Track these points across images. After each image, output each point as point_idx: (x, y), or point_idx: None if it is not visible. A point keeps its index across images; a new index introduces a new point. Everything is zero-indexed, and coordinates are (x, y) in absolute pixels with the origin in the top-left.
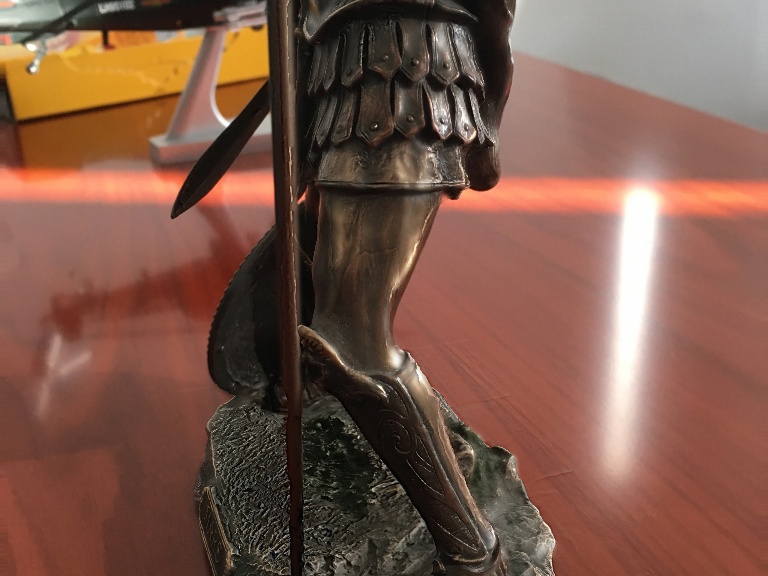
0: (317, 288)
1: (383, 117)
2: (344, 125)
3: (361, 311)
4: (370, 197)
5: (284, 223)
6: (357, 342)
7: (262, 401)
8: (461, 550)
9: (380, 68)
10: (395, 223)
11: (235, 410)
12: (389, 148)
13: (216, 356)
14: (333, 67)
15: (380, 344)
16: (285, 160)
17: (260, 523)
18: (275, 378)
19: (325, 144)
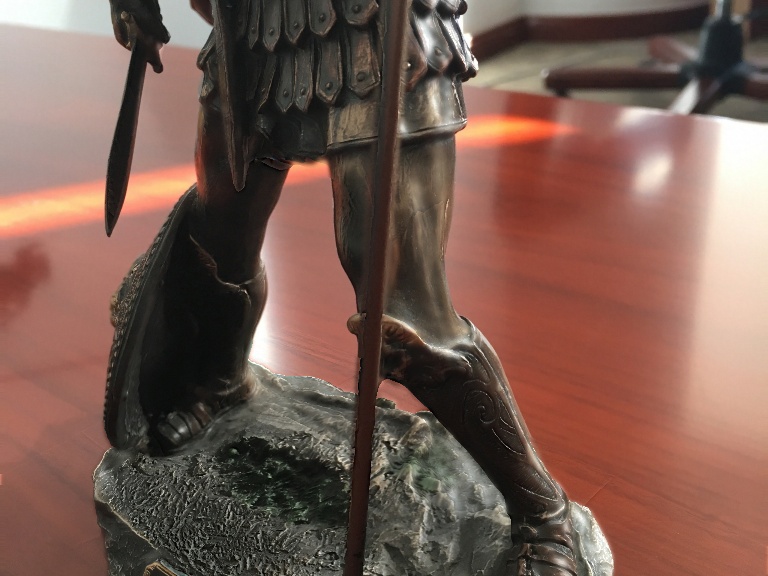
0: (362, 268)
1: (414, 53)
2: (367, 70)
3: (424, 280)
4: (411, 148)
5: (388, 186)
6: (427, 315)
7: (147, 448)
8: (546, 506)
9: None
10: (437, 173)
11: (118, 469)
12: (423, 88)
13: (121, 406)
14: (330, 6)
15: (448, 311)
16: (397, 106)
17: (251, 575)
18: (155, 417)
19: (340, 98)
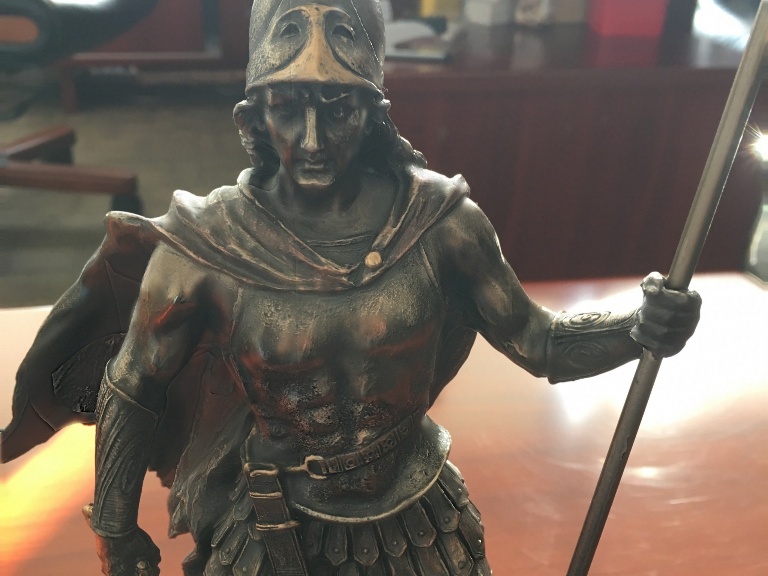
0: None
1: (479, 532)
2: (464, 559)
3: None
4: None
5: None
6: None
7: None
8: None
9: (465, 501)
10: None
11: None
12: None
13: None
14: (430, 526)
15: None
16: None
17: None
18: None
19: None
